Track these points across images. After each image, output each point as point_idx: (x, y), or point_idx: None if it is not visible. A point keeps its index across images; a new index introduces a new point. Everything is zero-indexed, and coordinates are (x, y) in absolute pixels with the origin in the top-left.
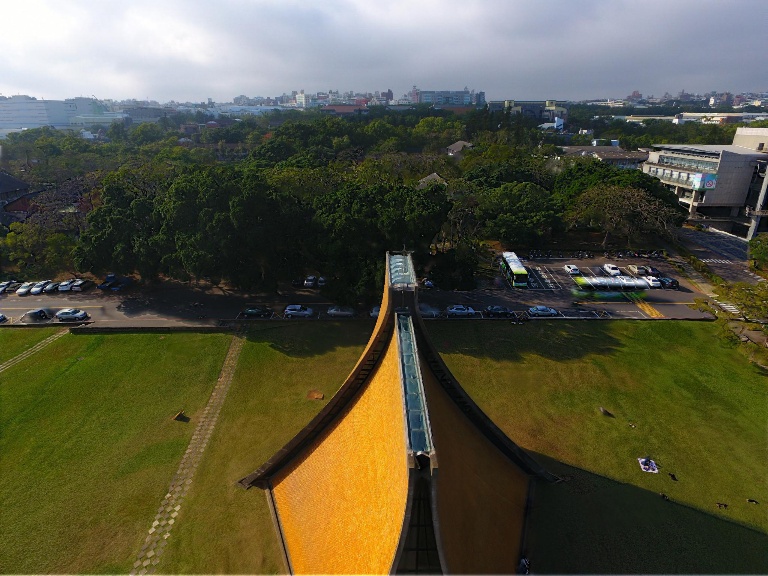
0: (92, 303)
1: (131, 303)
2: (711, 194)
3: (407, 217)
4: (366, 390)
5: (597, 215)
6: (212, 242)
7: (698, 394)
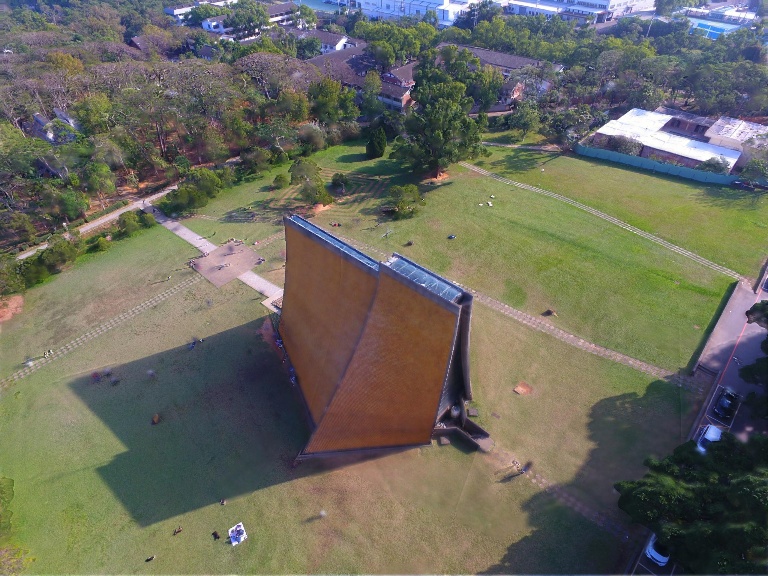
0: None
1: None
2: None
3: None
4: None
5: None
6: None
7: None
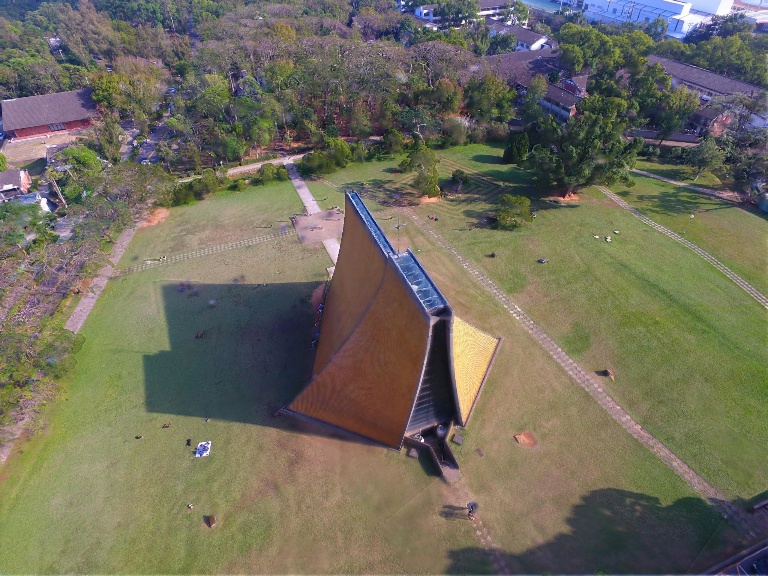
0: None
1: None
2: None
3: None
4: None
5: None
6: None
7: None
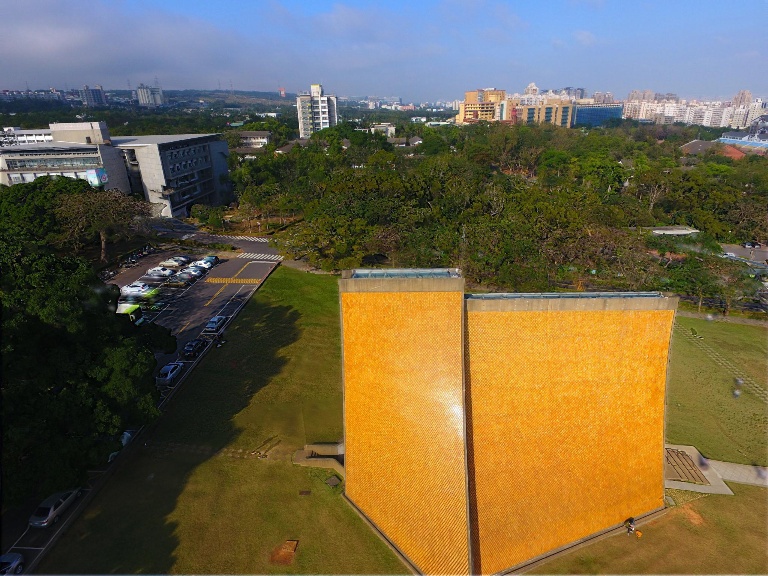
0: None
1: None
2: (109, 187)
3: None
4: (472, 388)
5: None
6: None
7: None
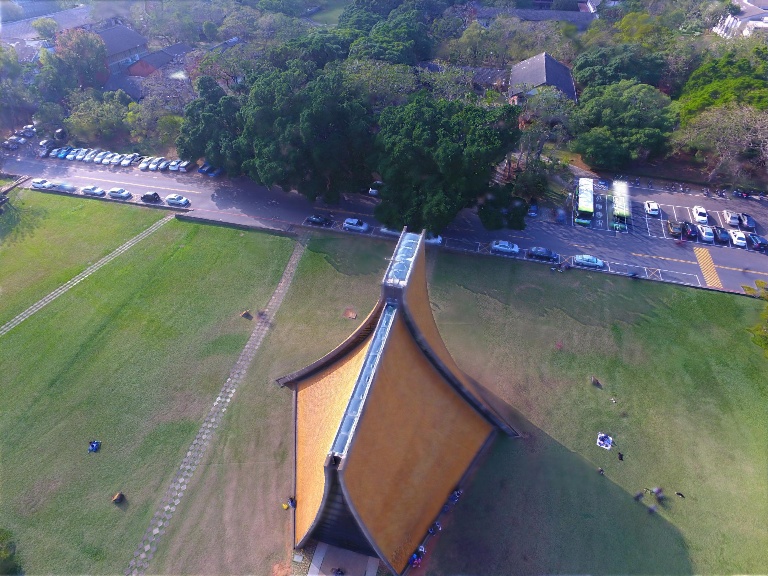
0: (193, 188)
1: (223, 192)
2: None
3: (465, 150)
4: (362, 349)
5: (705, 147)
6: (283, 154)
7: (700, 383)
